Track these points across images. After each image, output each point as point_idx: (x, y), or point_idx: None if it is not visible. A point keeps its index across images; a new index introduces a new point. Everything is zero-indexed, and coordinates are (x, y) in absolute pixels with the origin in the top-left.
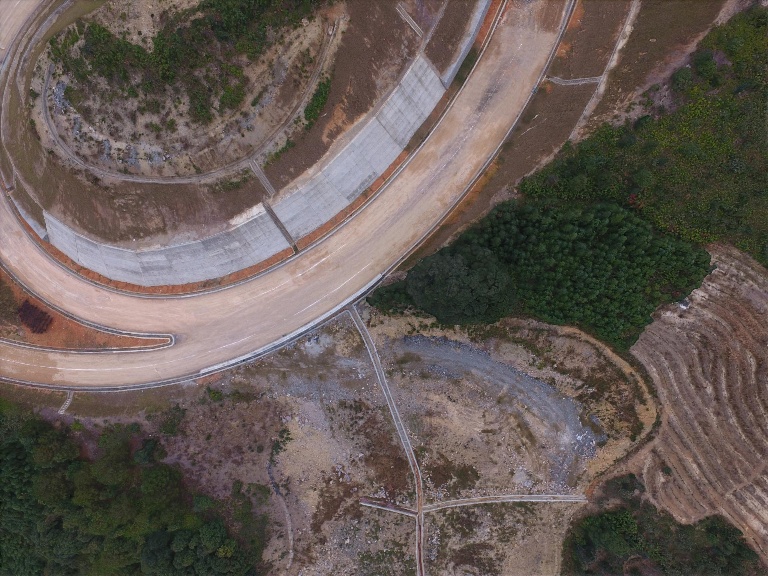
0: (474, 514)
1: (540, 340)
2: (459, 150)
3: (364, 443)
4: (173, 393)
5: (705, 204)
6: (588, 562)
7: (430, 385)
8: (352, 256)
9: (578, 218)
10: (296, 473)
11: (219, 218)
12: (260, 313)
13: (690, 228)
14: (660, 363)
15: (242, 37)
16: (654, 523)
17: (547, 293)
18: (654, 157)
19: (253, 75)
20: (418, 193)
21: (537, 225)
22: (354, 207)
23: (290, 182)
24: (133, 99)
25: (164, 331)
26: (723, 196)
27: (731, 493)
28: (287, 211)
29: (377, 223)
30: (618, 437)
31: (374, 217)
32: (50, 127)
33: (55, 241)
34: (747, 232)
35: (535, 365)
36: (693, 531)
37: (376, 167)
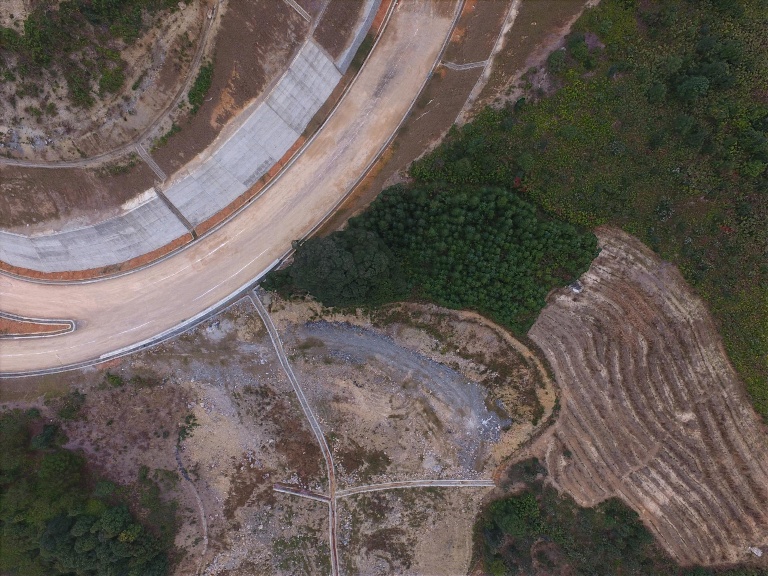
0: (385, 499)
1: (443, 325)
2: (356, 135)
3: (273, 429)
4: (73, 378)
5: (590, 187)
6: (496, 546)
7: (335, 370)
8: (250, 241)
9: (466, 202)
10: (205, 459)
11: (111, 203)
12: (160, 299)
13: (577, 211)
14: (557, 347)
15: (117, 20)
16: (556, 506)
17: (440, 277)
18: (536, 140)
19: (131, 59)
20: (315, 178)
21: (426, 209)
22: (252, 193)
23: (181, 167)
24: (11, 83)
25: (65, 317)
26: (607, 179)
27: (628, 476)
28: (180, 196)
29: (275, 208)
30: (521, 421)
31: (272, 202)
32: None
33: None
34: (632, 215)
35: (438, 350)
36: (592, 514)
37: (272, 152)
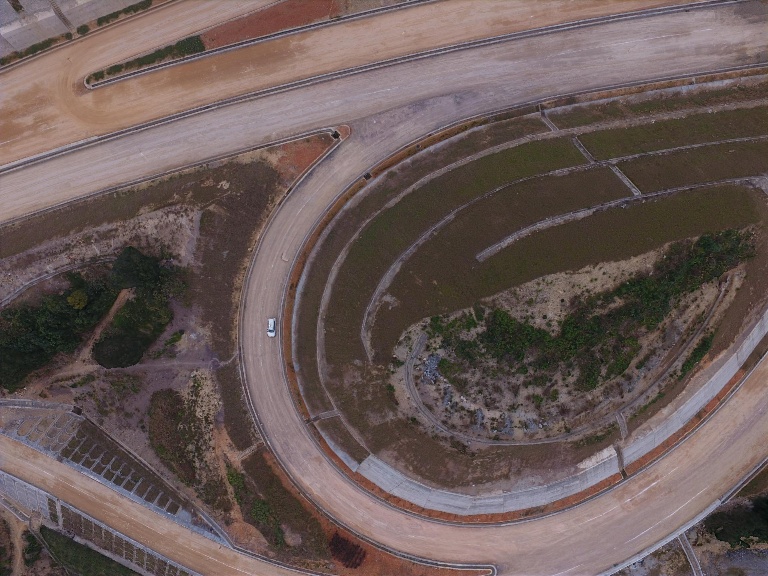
0: None
1: None
2: None
3: None
4: None
5: None
6: None
7: None
8: (685, 480)
9: None
10: None
11: (568, 463)
12: (587, 541)
13: None
14: None
15: None
16: None
17: None
18: None
19: (645, 341)
20: (756, 413)
21: None
22: (687, 429)
23: (643, 423)
24: (520, 374)
25: (484, 561)
26: None
27: None
28: (634, 449)
29: (711, 445)
30: None
31: (708, 439)
32: (411, 393)
33: (366, 472)
34: None
35: None
36: None
37: (716, 391)
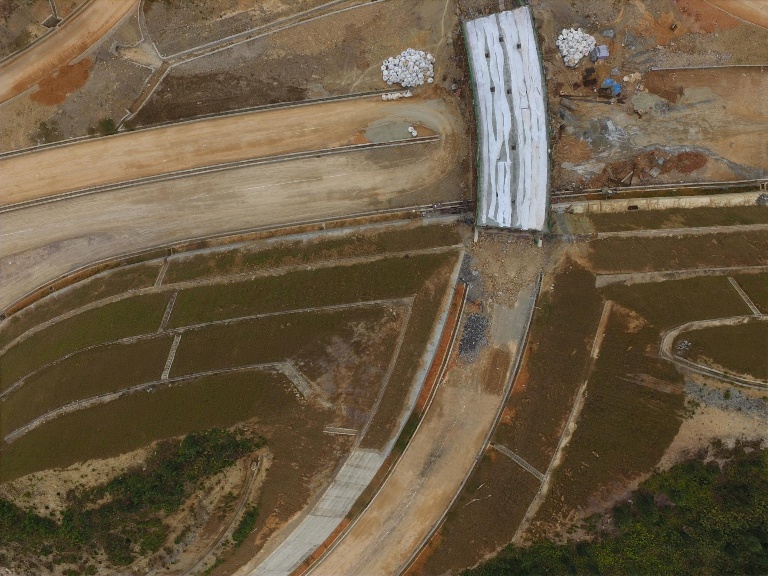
0: None
1: None
2: (402, 517)
3: None
4: None
5: None
6: None
7: None
8: None
9: None
10: None
11: None
12: None
13: None
14: None
15: None
16: None
17: None
18: None
19: (173, 521)
20: (361, 560)
21: None
22: (296, 575)
23: None
24: None
25: None
26: None
27: None
28: None
29: None
30: None
31: None
32: None
33: None
34: None
35: None
36: None
37: (316, 541)
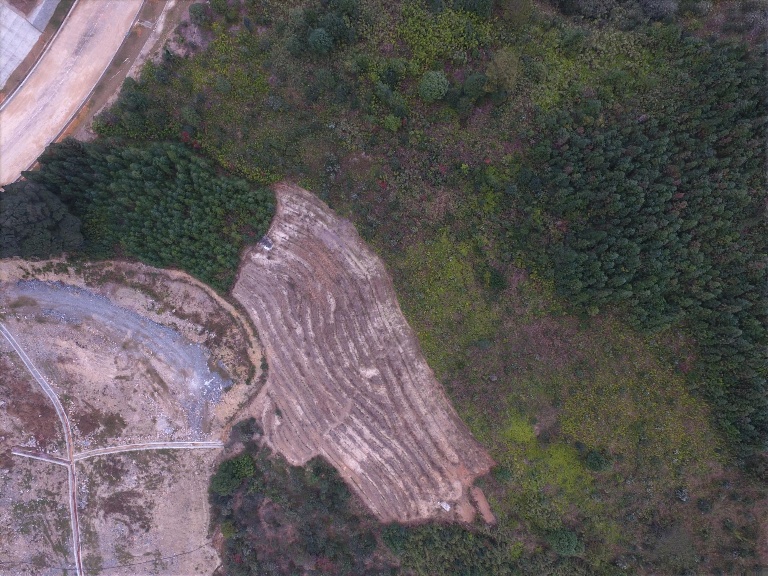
0: (120, 462)
1: (158, 285)
2: (55, 93)
3: (2, 390)
4: None
5: (260, 143)
6: (226, 508)
7: (52, 330)
8: None
9: (142, 157)
10: None
11: None
12: None
13: (252, 167)
14: (258, 305)
15: None
16: (268, 465)
17: (130, 233)
18: (196, 94)
19: None
20: (15, 135)
21: (104, 164)
22: None
23: None
24: None
25: None
26: (274, 135)
27: (328, 433)
28: None
29: None
30: (239, 382)
31: None
32: None
33: None
34: (302, 171)
35: (154, 310)
36: (299, 472)
37: None
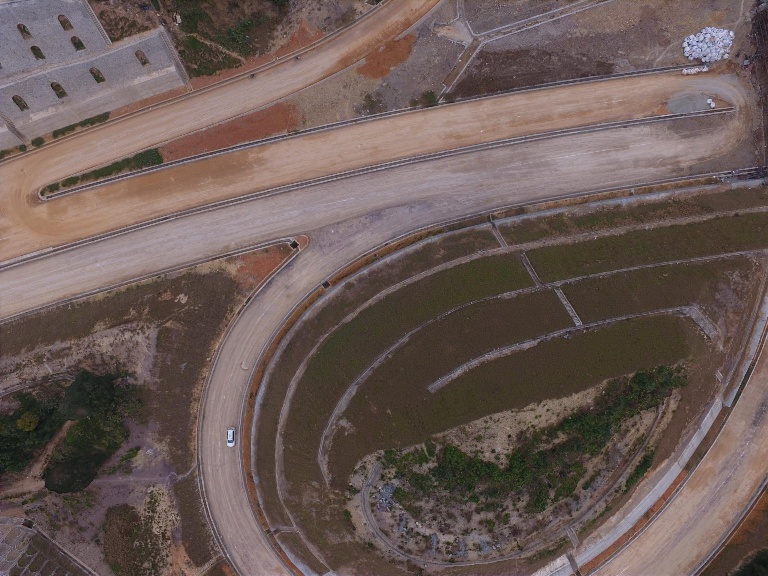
0: None
1: None
2: (737, 466)
3: None
4: None
5: None
6: None
7: None
8: None
9: None
10: None
11: (524, 574)
12: None
13: None
14: None
15: None
16: None
17: None
18: None
19: (590, 465)
20: (699, 511)
21: None
22: (636, 529)
23: (593, 531)
24: (472, 502)
25: None
26: None
27: None
28: (586, 555)
29: (659, 543)
30: None
31: (656, 537)
32: (368, 519)
33: None
34: None
35: None
36: None
37: (661, 493)
